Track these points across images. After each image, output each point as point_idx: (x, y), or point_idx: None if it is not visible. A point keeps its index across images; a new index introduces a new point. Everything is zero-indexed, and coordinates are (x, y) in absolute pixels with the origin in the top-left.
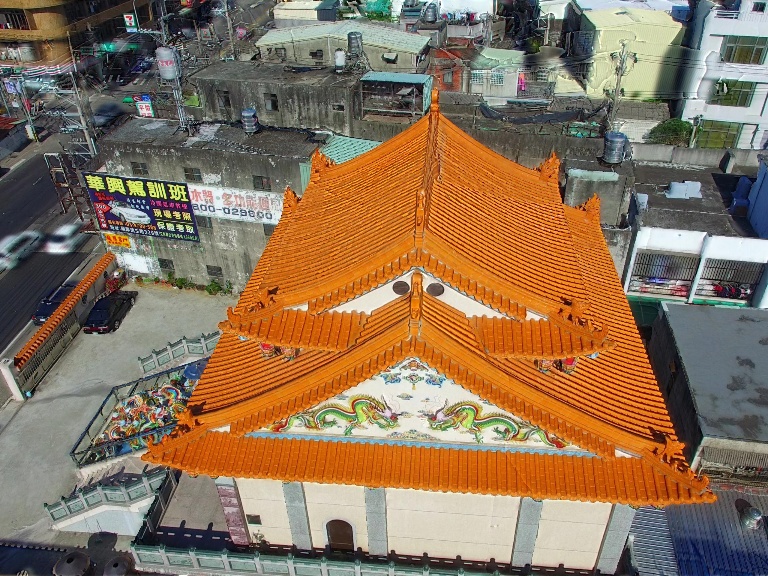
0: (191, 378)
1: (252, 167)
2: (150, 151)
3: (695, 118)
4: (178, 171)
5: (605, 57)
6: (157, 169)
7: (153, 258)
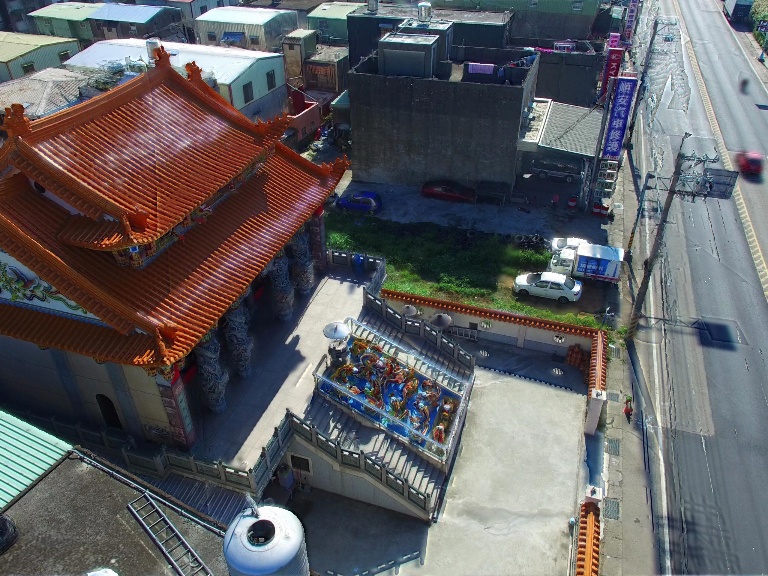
0: (344, 324)
1: None
2: None
3: None
4: None
5: None
6: None
7: None
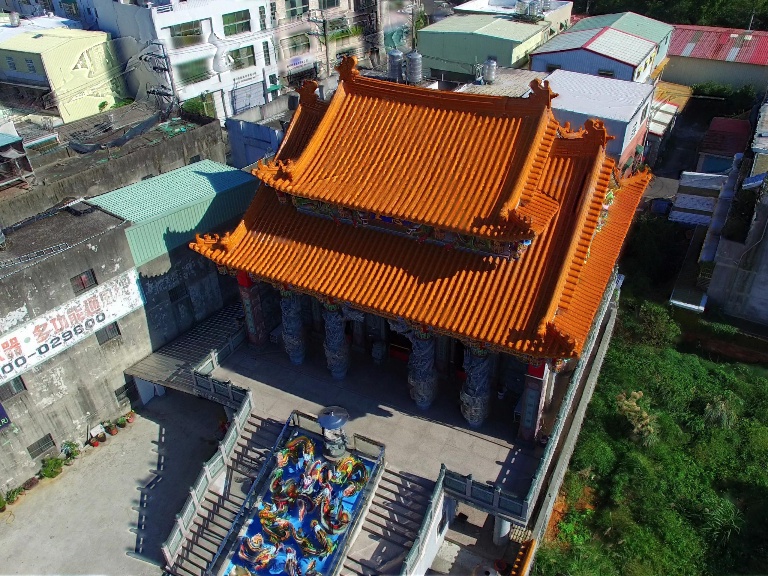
0: (343, 424)
1: (68, 269)
2: None
3: (201, 96)
4: None
5: (139, 62)
6: None
7: None
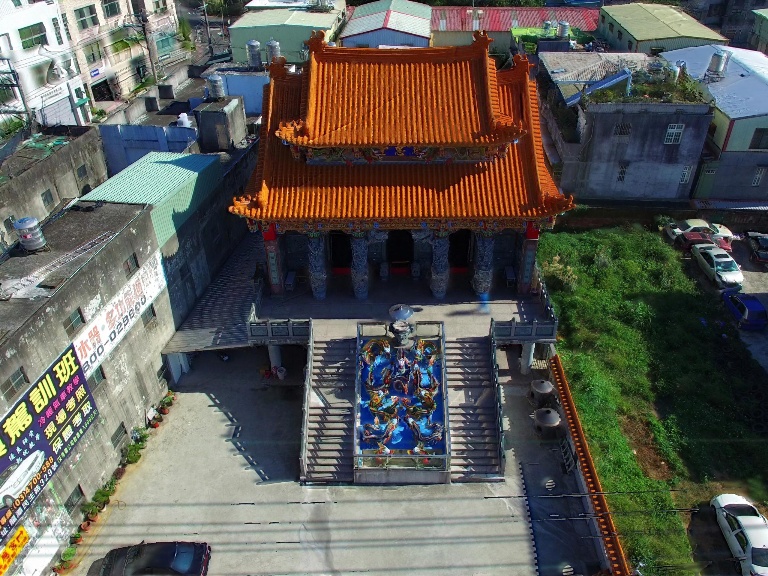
0: None
1: (121, 253)
2: (23, 339)
3: None
4: (60, 335)
5: None
6: (37, 359)
7: (59, 514)
